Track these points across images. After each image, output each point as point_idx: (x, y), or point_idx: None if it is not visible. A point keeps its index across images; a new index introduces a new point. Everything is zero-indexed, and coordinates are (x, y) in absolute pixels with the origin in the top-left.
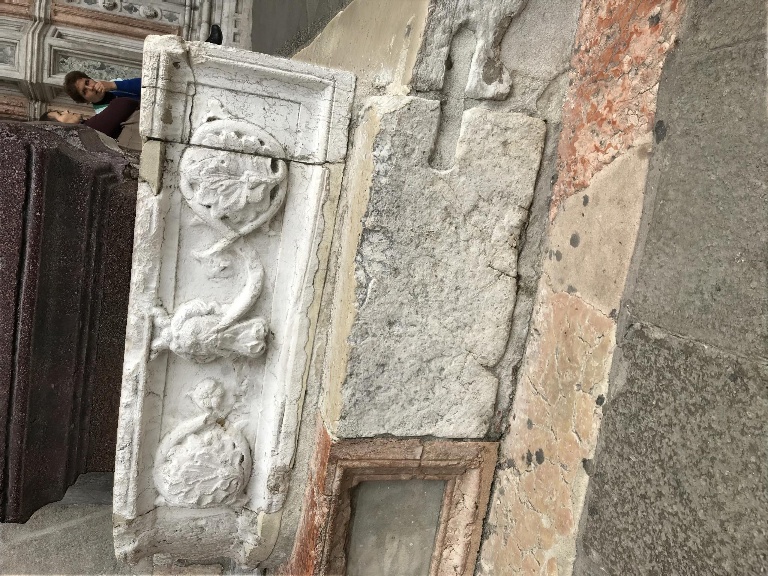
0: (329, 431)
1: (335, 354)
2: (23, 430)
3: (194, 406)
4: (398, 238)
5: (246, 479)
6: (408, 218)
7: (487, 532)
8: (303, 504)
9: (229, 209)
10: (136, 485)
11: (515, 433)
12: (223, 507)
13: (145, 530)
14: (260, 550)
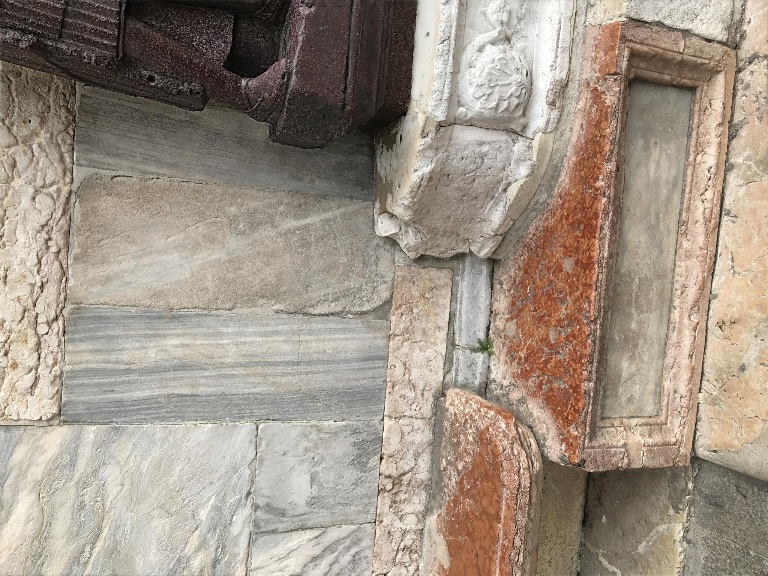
0: (615, 19)
1: None
2: (360, 24)
3: (487, 23)
4: None
5: None
6: None
7: (733, 133)
8: (575, 121)
9: None
10: (451, 82)
11: (754, 31)
12: (503, 133)
13: (441, 152)
14: (528, 187)
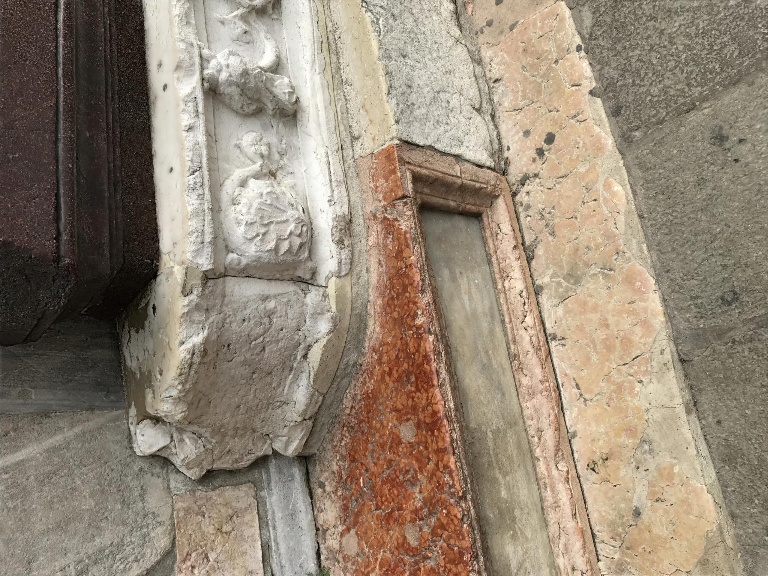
0: (386, 143)
1: (366, 87)
2: (73, 154)
3: (244, 157)
4: None
5: (310, 237)
6: None
7: (529, 255)
8: (370, 259)
9: None
10: (212, 220)
11: (516, 156)
12: (289, 284)
13: (213, 314)
14: (332, 346)
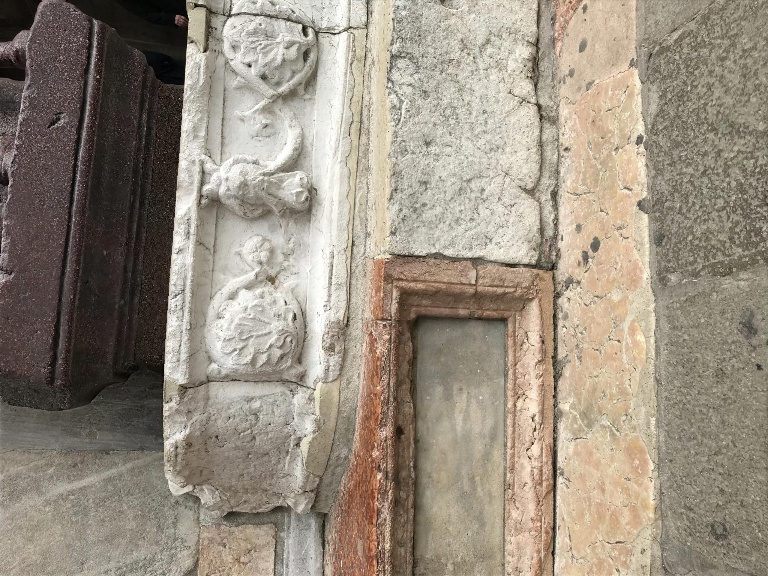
0: (381, 255)
1: (378, 183)
2: (76, 285)
3: (243, 264)
4: (423, 64)
5: (300, 343)
6: (430, 46)
7: (559, 371)
8: (361, 366)
9: (268, 66)
10: (189, 340)
11: (566, 250)
12: (277, 385)
13: (197, 414)
14: (319, 443)
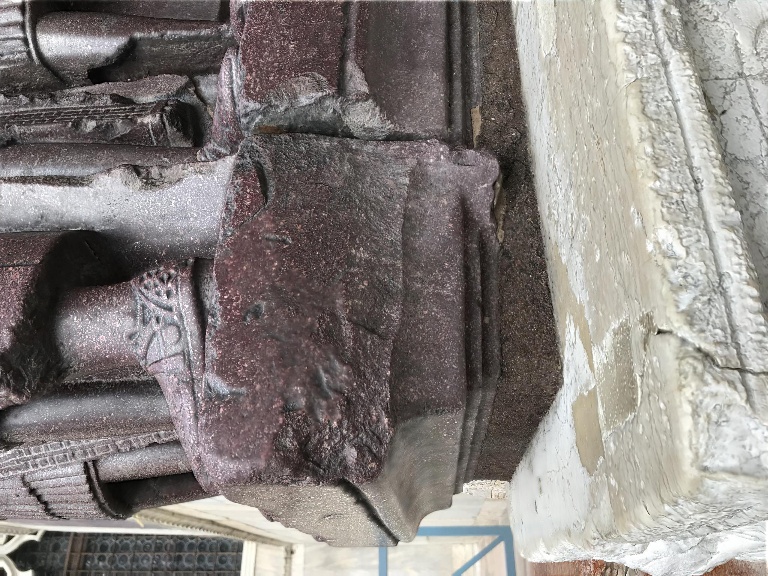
0: None
1: None
2: None
3: None
4: None
5: None
6: None
7: None
8: None
9: None
10: None
11: None
12: None
13: None
14: None
